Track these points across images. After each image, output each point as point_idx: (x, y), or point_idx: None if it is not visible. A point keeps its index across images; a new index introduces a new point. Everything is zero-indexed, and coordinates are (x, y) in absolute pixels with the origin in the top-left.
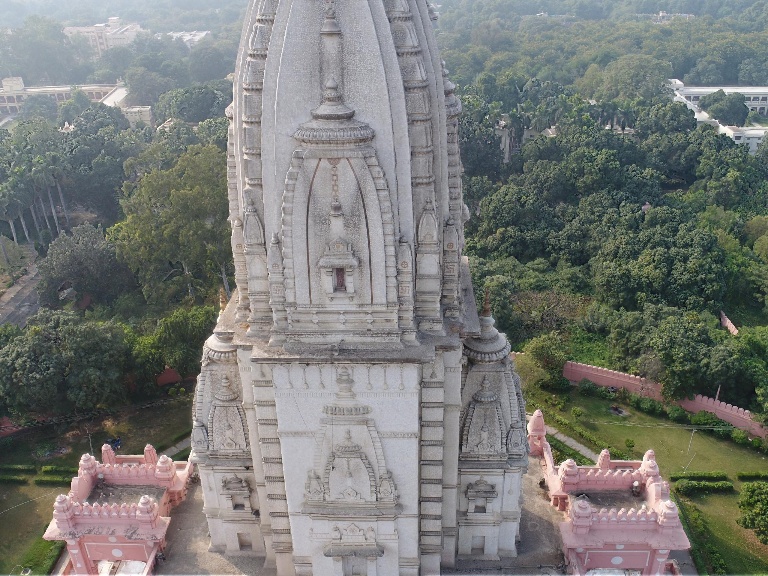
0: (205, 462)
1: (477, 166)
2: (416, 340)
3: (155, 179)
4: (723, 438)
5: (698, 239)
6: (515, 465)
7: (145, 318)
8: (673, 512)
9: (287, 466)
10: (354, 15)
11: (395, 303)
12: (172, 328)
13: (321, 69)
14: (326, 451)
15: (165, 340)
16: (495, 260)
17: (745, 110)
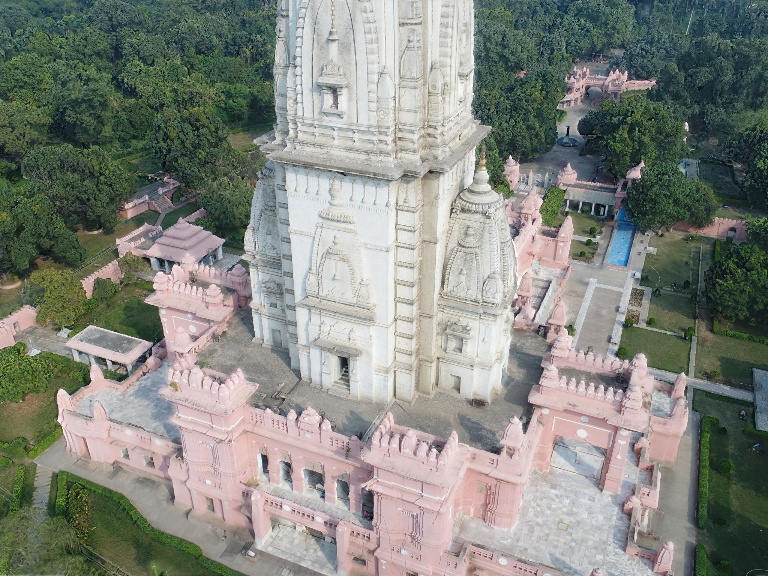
0: None
1: None
2: None
3: None
4: None
5: None
6: None
7: None
8: None
9: None
10: None
11: None
12: None
13: None
14: None
15: None
16: None
17: None
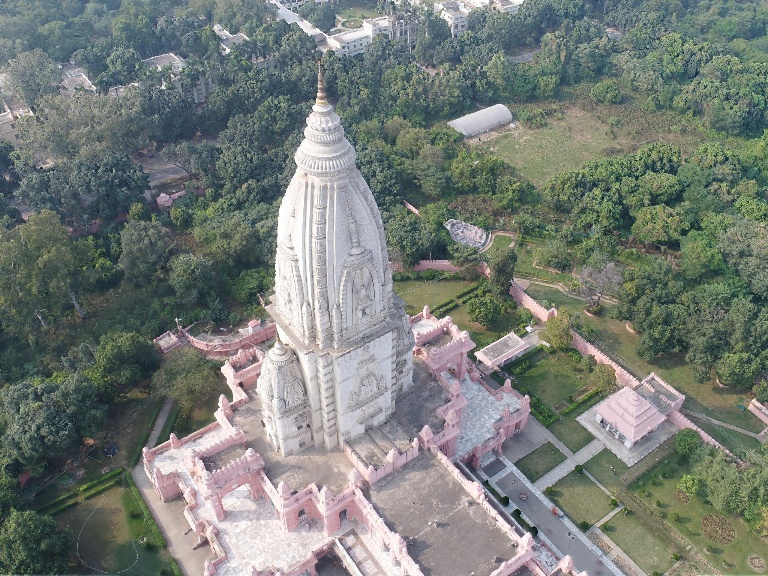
0: (286, 415)
1: (182, 128)
2: (390, 319)
3: (5, 253)
4: (441, 279)
5: (374, 156)
6: None
7: (40, 360)
8: (468, 335)
9: (342, 395)
10: (359, 211)
11: (383, 310)
12: (113, 359)
13: (351, 236)
14: (359, 380)
15: (109, 369)
16: (250, 208)
17: (333, 15)
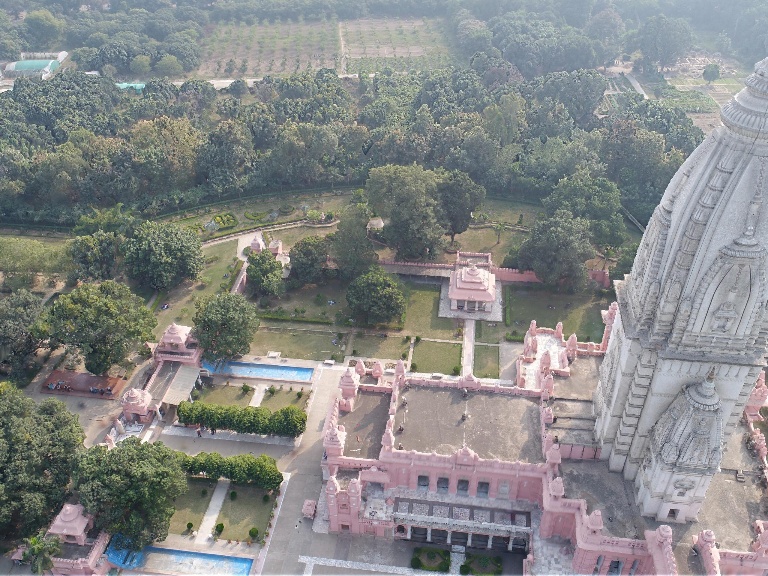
0: None
1: None
2: (639, 329)
3: None
4: None
5: None
6: (658, 459)
7: None
8: None
9: None
10: None
11: None
12: None
13: None
14: None
15: None
16: None
17: None
